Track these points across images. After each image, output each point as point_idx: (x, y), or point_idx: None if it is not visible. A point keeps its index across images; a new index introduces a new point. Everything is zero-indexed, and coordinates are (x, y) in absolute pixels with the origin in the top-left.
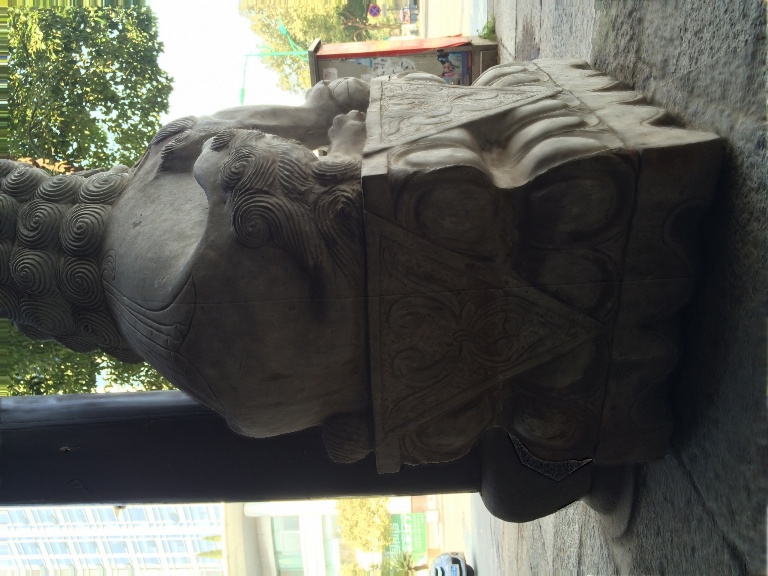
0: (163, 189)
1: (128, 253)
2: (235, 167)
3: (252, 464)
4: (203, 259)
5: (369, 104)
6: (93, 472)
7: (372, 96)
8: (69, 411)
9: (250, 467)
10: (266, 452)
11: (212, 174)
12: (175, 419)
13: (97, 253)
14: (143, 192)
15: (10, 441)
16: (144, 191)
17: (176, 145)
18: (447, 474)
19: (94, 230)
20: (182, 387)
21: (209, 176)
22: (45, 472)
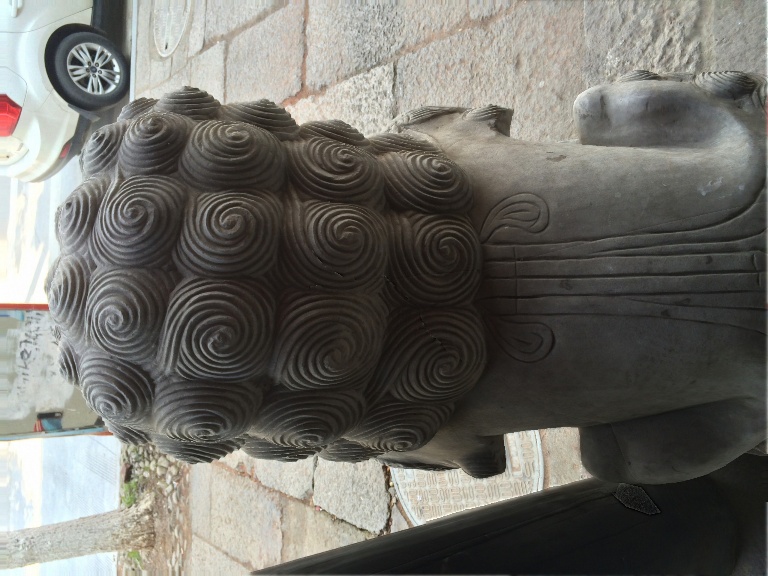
0: None
1: (588, 180)
2: None
3: None
4: None
5: None
6: None
7: None
8: None
9: None
10: (600, 566)
11: (693, 88)
12: (471, 549)
13: (469, 209)
14: (500, 143)
15: None
16: (500, 142)
17: None
18: (721, 554)
19: (463, 175)
20: (750, 341)
21: (691, 89)
22: None
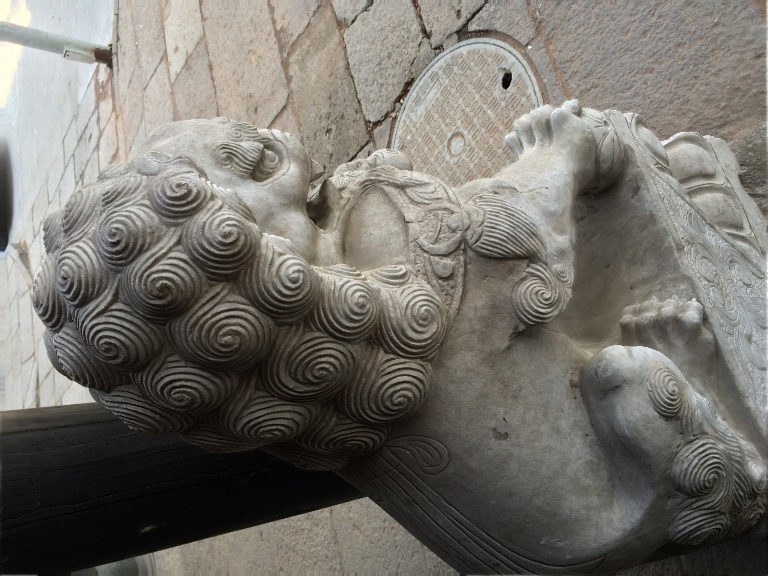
0: (521, 374)
1: (490, 477)
2: (709, 481)
3: (340, 496)
4: (627, 547)
5: (668, 244)
6: (172, 537)
7: (670, 230)
8: (137, 472)
9: (337, 498)
10: None
11: (665, 460)
12: (276, 468)
13: (397, 425)
14: (493, 369)
15: (57, 530)
16: (494, 367)
17: (550, 314)
18: None
19: (415, 407)
20: None
21: (661, 461)
22: (113, 554)
